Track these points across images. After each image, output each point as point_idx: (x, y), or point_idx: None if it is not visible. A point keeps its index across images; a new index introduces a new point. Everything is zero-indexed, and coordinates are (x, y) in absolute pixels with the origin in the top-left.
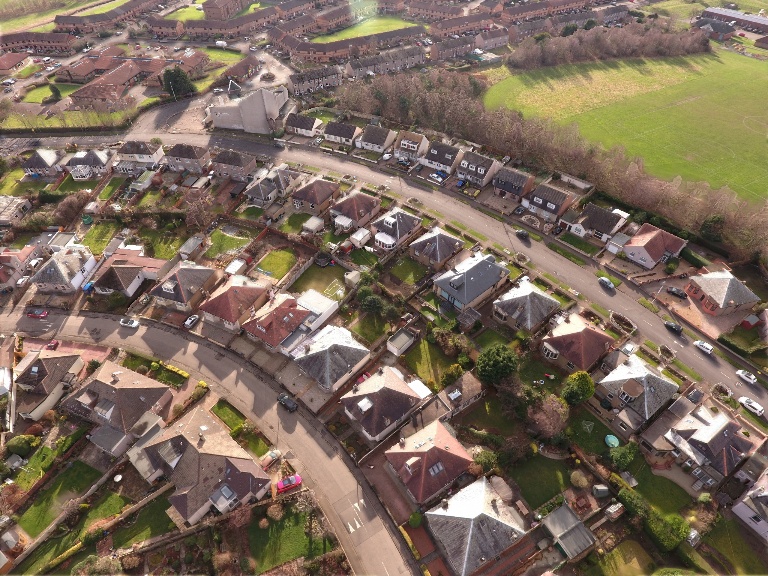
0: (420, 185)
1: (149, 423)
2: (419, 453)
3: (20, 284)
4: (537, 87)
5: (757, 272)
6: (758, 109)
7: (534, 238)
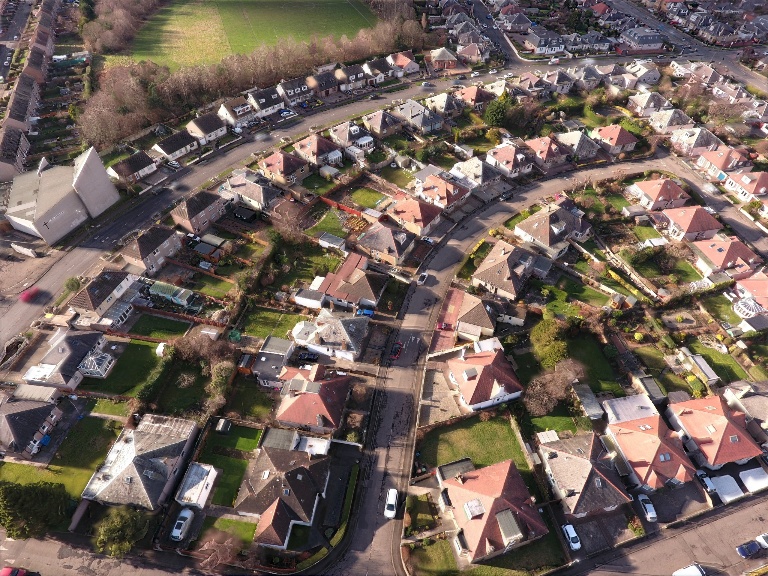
0: (292, 123)
1: (531, 245)
2: (551, 143)
3: (346, 374)
4: (168, 52)
5: (428, 49)
6: (275, 2)
7: (379, 95)
